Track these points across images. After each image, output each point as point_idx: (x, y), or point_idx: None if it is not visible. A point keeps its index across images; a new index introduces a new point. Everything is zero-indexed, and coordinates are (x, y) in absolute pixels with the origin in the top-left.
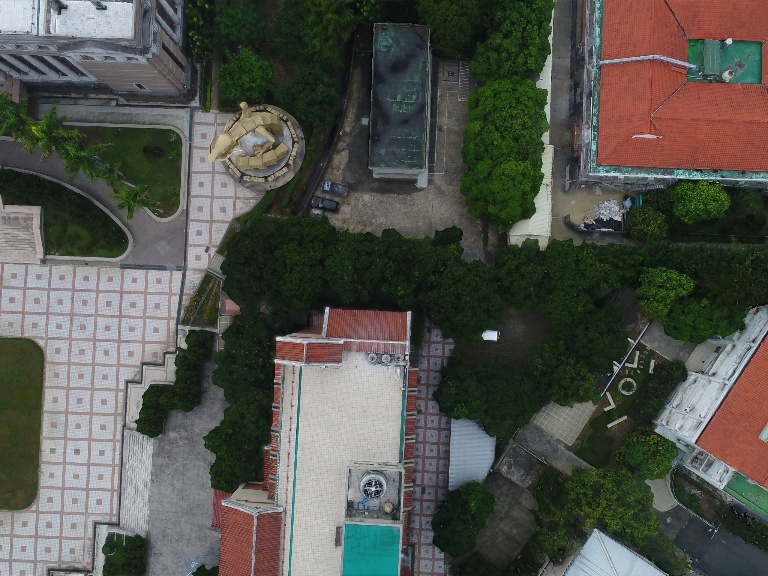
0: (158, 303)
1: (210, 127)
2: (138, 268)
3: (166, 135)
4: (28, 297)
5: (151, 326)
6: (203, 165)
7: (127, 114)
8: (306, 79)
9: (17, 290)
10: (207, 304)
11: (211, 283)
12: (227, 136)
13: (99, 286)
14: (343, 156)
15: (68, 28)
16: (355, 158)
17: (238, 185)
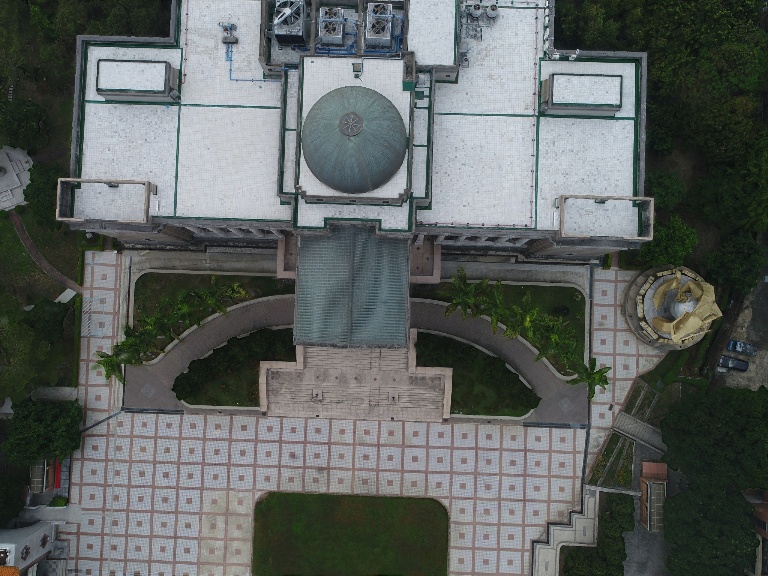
0: (563, 462)
1: (610, 284)
2: (541, 426)
3: (568, 293)
4: (431, 456)
5: (556, 485)
6: (604, 322)
7: (527, 271)
8: (739, 248)
9: (420, 449)
10: (617, 464)
11: (620, 443)
12: (698, 319)
13: (502, 445)
14: (747, 314)
15: (566, 221)
16: (759, 316)
17: (640, 342)
